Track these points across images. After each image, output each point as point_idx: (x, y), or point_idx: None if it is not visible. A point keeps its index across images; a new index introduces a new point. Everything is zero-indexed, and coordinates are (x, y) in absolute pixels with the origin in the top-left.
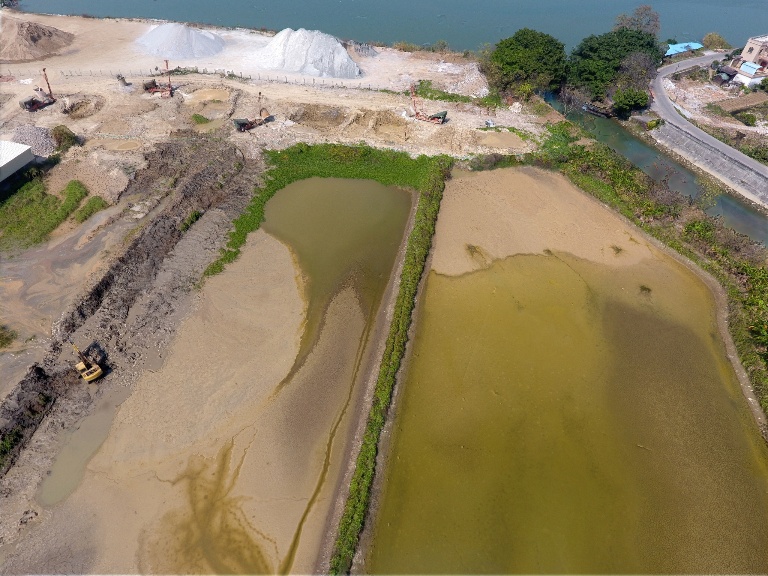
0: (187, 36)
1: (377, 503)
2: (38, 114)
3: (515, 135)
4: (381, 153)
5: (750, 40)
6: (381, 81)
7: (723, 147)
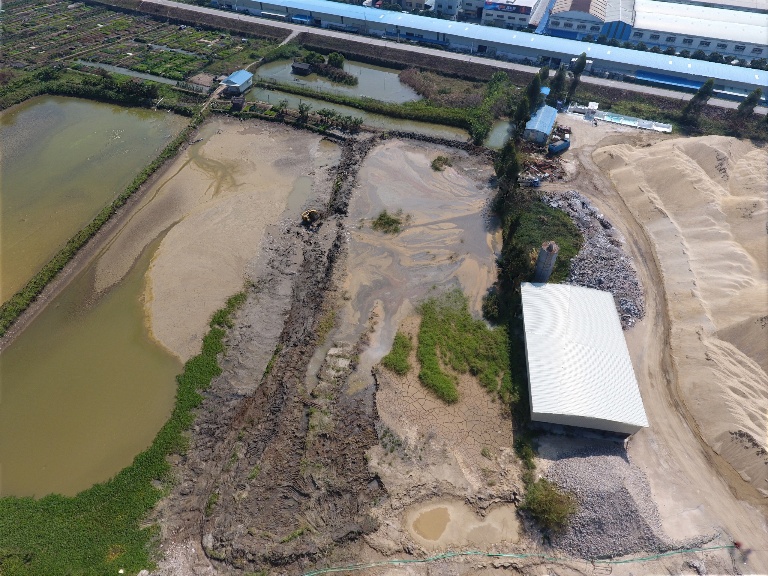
0: None
1: None
2: None
3: None
4: None
5: None
6: None
7: None
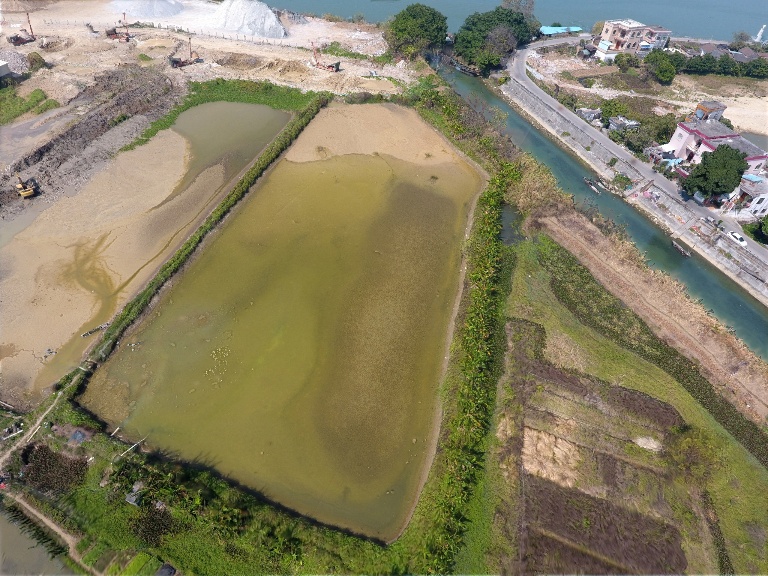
0: None
1: (191, 264)
2: (20, 47)
3: (391, 83)
4: (279, 88)
5: (606, 22)
6: (301, 41)
7: (544, 96)
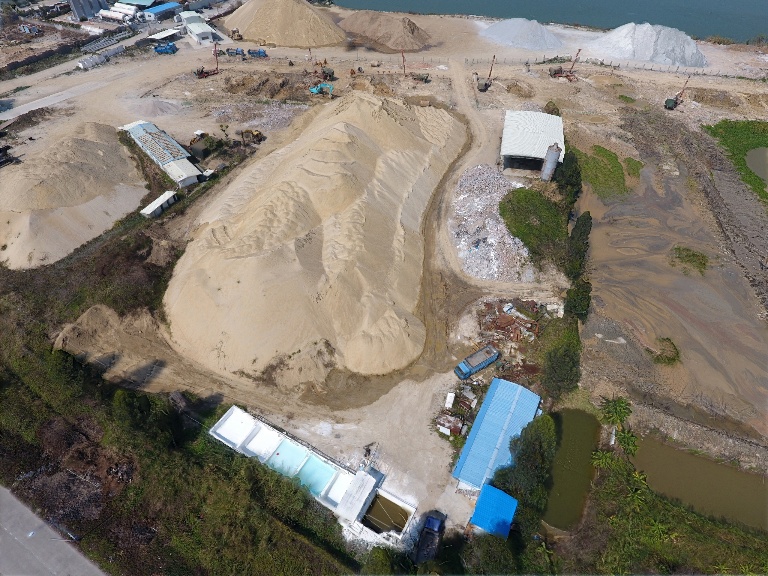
0: (540, 30)
1: None
2: (491, 94)
3: None
4: None
5: None
6: (728, 69)
7: None
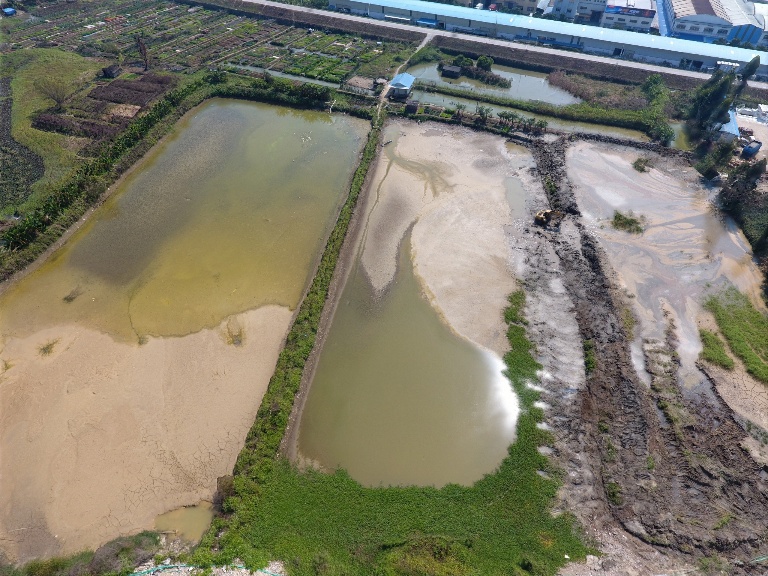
0: None
1: None
2: None
3: None
4: (348, 572)
5: None
6: None
7: None
